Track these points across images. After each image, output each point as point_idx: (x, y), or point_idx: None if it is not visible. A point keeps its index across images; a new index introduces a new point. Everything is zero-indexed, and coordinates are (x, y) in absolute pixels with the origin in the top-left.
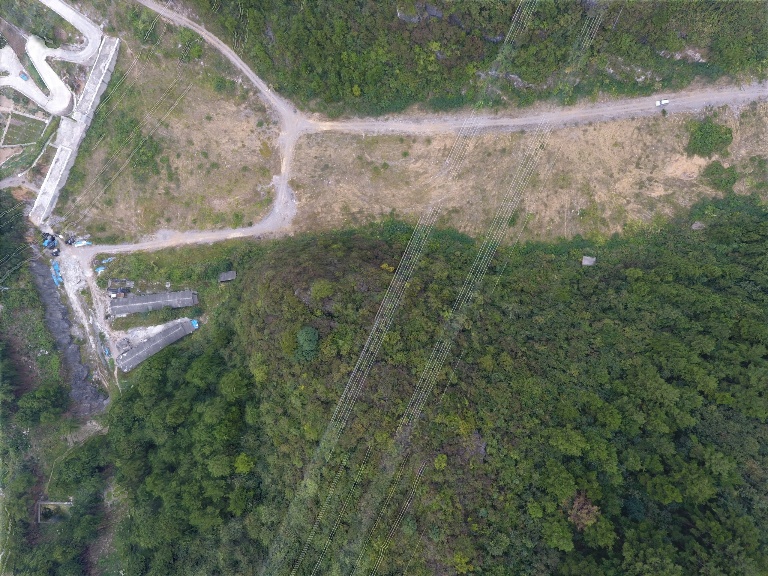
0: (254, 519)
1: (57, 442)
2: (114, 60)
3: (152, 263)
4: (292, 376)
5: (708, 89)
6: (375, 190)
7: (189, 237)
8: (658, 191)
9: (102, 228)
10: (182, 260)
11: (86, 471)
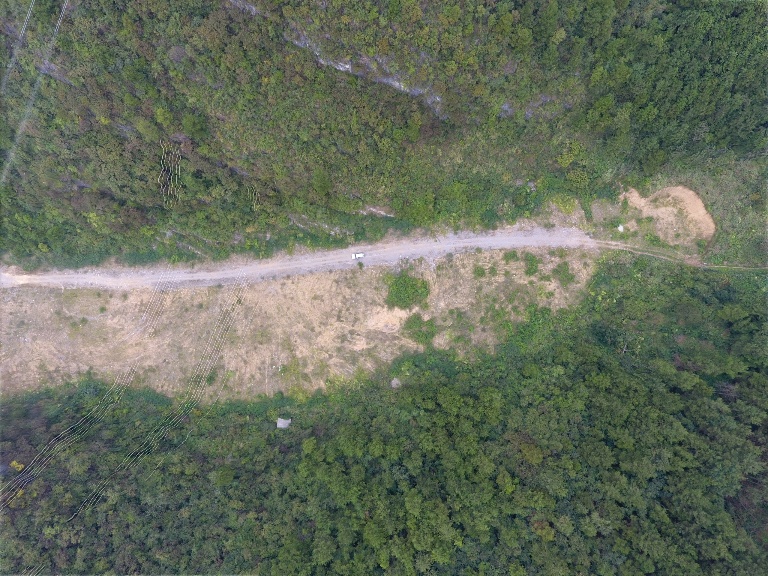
0: None
1: None
2: None
3: None
4: None
5: (403, 241)
6: (72, 347)
7: None
8: (360, 344)
9: None
10: None
11: None
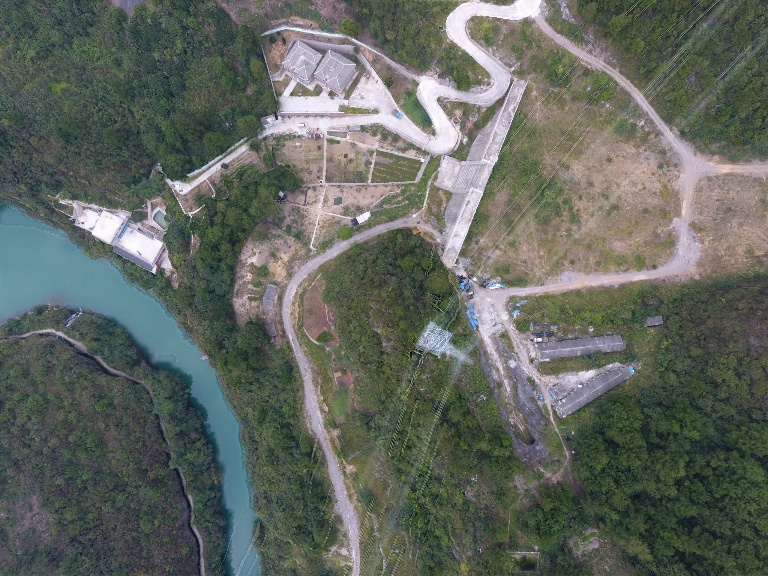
0: None
1: (509, 489)
2: None
3: (568, 306)
4: None
5: None
6: None
7: (594, 279)
8: None
9: (508, 270)
10: (590, 303)
11: (566, 522)
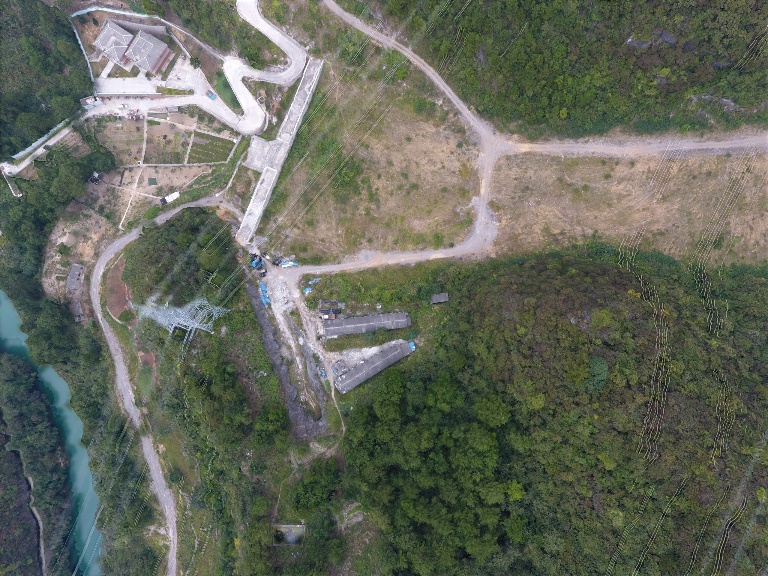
0: (533, 547)
1: (282, 464)
2: (316, 81)
3: (359, 284)
4: (576, 405)
5: None
6: (576, 212)
7: (391, 258)
8: None
9: (305, 248)
10: (386, 281)
11: (325, 495)
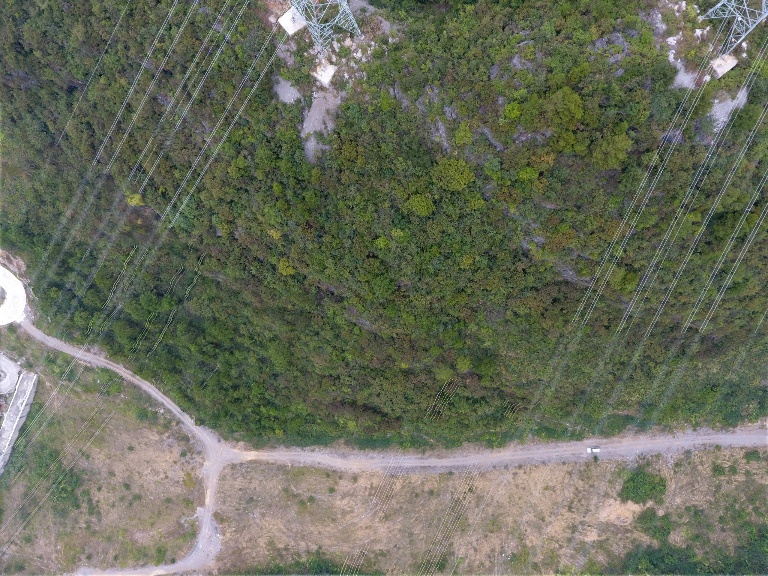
0: None
1: None
2: (33, 393)
3: None
4: None
5: (641, 436)
6: (301, 526)
7: (110, 575)
8: (591, 536)
9: (21, 567)
10: None
11: None
